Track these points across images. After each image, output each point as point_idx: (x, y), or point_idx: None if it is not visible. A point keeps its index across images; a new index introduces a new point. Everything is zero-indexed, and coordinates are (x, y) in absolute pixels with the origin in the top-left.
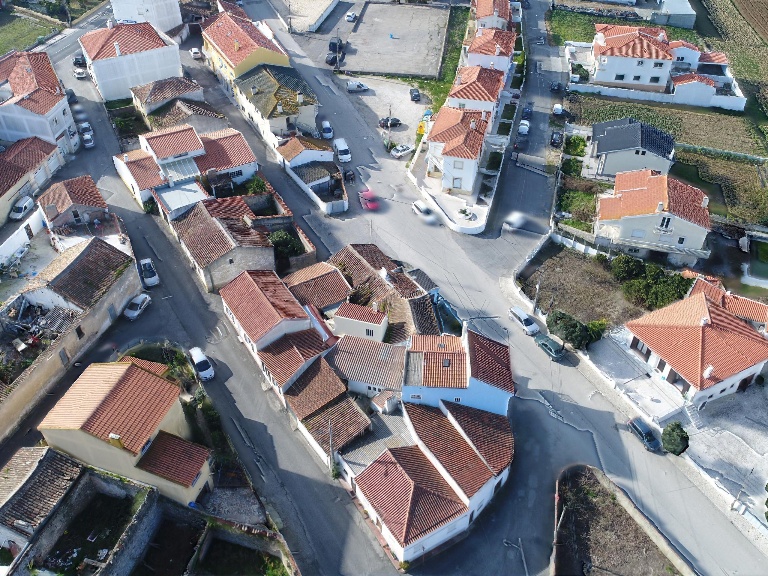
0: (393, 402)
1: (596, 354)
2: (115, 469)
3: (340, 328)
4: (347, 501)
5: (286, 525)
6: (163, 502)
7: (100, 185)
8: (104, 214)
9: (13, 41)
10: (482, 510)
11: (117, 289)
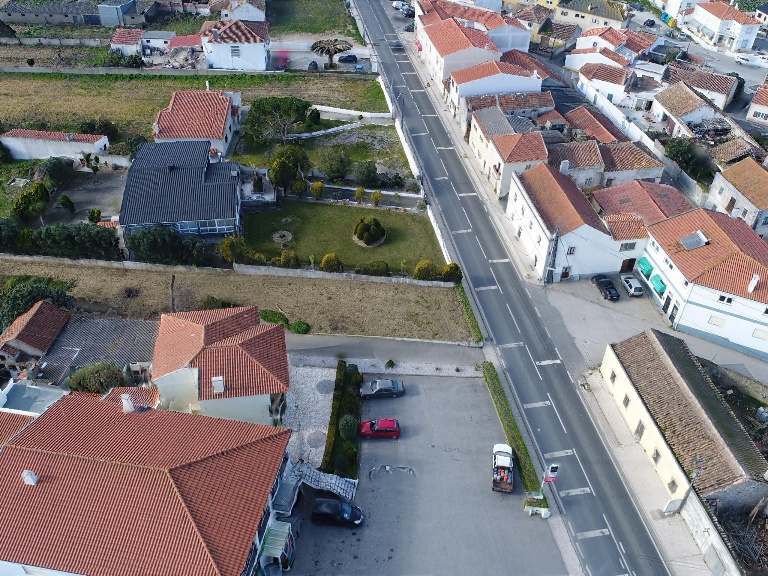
0: None
1: None
2: None
3: None
4: None
5: None
6: None
7: None
8: (637, 79)
9: (326, 8)
10: None
11: None
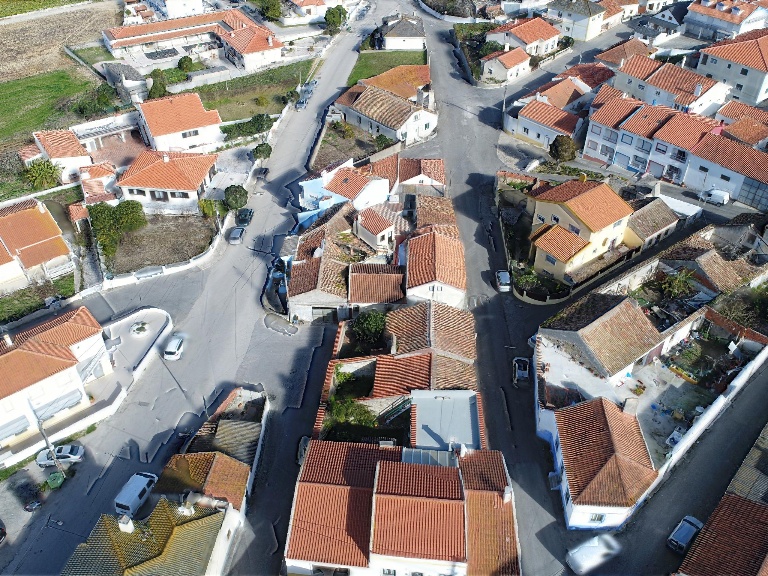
0: None
1: None
2: None
3: None
4: None
5: None
6: None
7: (556, 567)
8: None
9: None
10: None
11: None
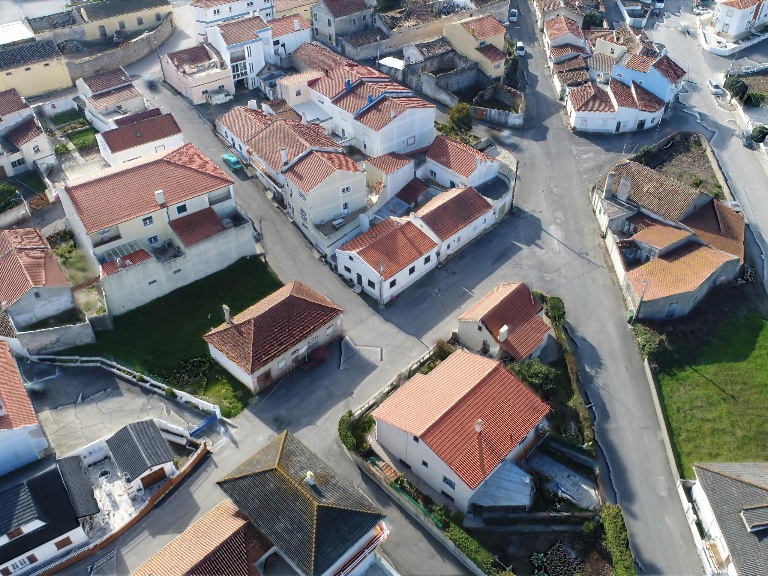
0: (607, 77)
1: (750, 111)
2: (466, 52)
3: (598, 47)
4: (561, 108)
5: (527, 104)
6: (479, 72)
7: None
8: None
9: None
10: (627, 131)
11: (495, 9)
